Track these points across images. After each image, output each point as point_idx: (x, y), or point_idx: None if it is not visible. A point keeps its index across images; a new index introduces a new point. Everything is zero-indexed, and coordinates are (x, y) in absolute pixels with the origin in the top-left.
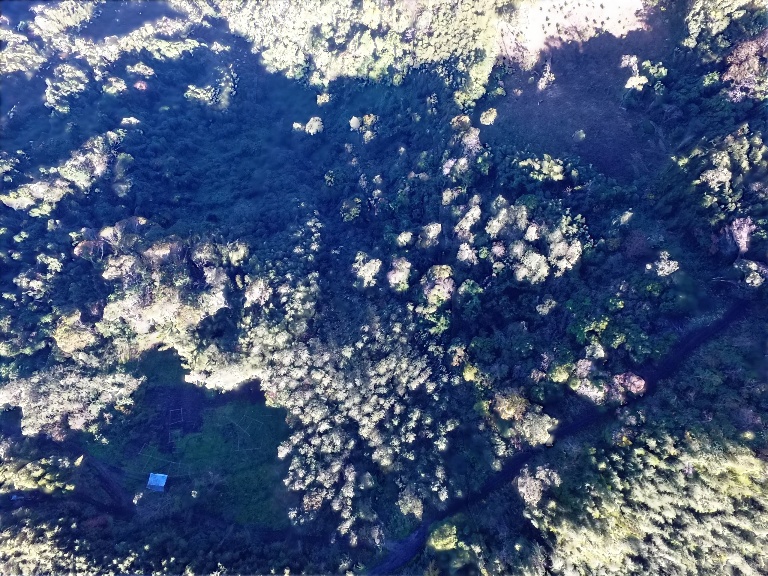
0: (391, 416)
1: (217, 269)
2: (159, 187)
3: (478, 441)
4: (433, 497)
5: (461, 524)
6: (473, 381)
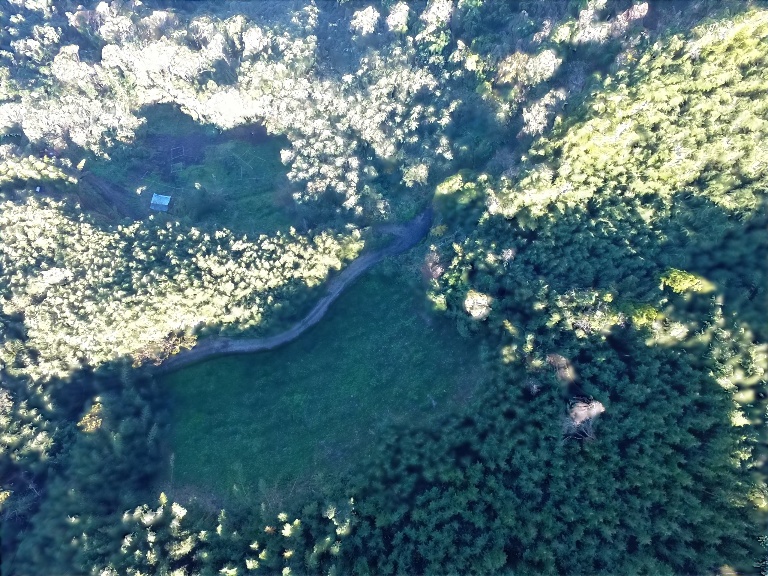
0: (393, 117)
1: (214, 29)
2: (155, 2)
3: (481, 113)
4: (438, 162)
5: (466, 175)
6: (475, 71)
